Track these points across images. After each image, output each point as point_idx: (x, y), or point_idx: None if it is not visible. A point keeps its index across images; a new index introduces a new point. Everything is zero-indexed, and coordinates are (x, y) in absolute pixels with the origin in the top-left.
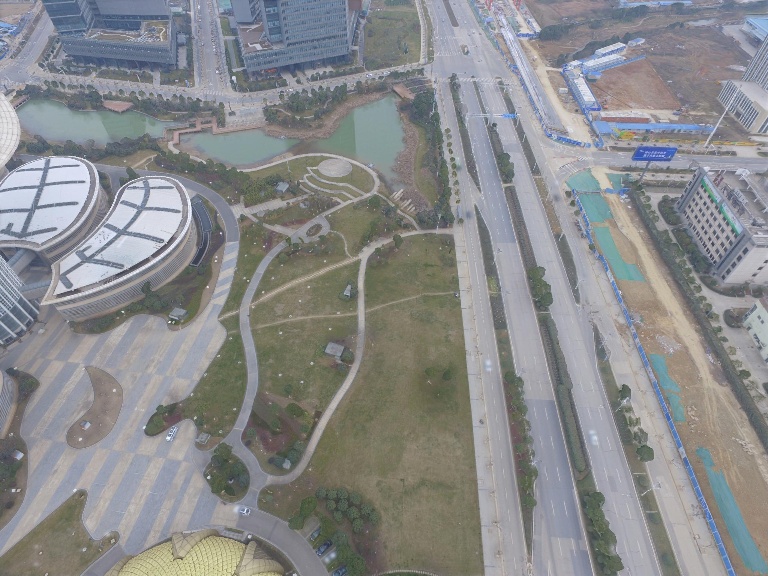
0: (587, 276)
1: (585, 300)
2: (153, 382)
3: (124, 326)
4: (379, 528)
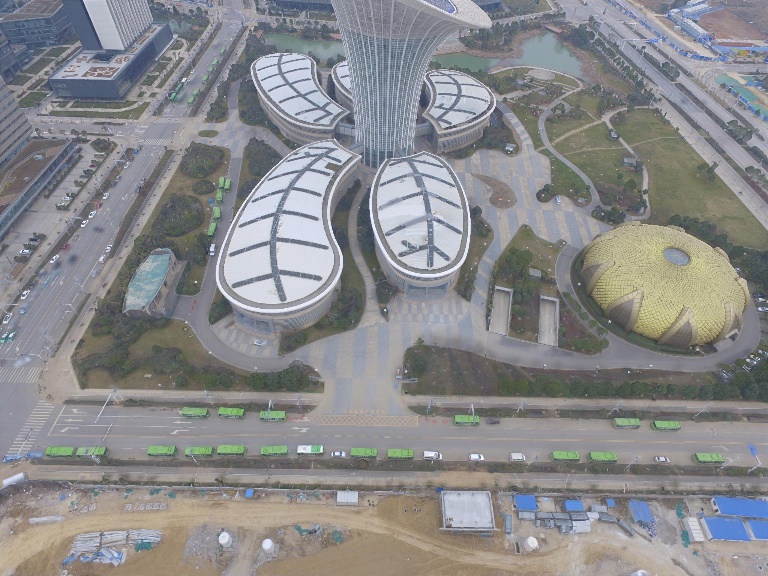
0: (761, 128)
1: (767, 140)
2: (522, 180)
3: (476, 155)
4: (716, 232)
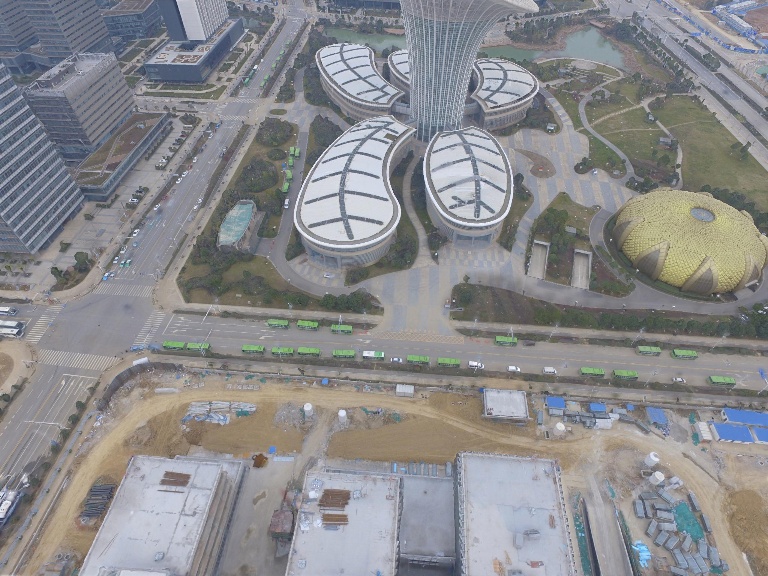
0: None
1: None
2: (561, 155)
3: (519, 133)
4: None
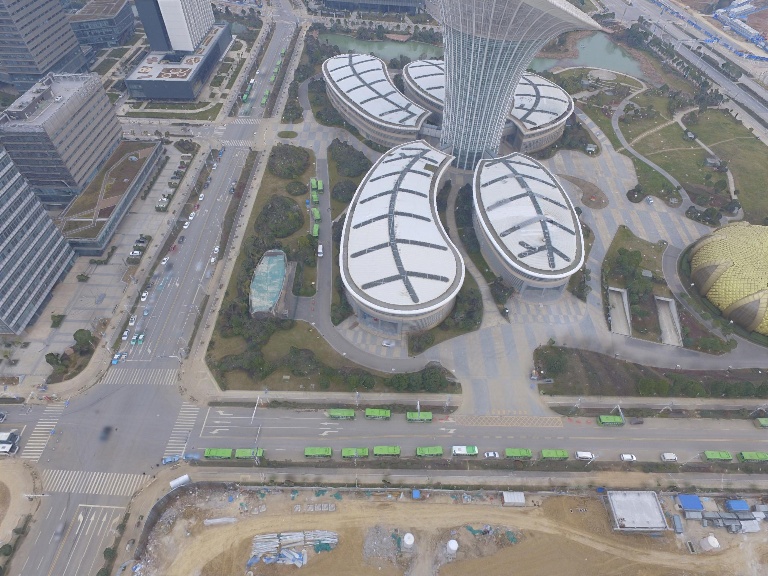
0: None
1: None
2: (609, 180)
3: (558, 156)
4: None
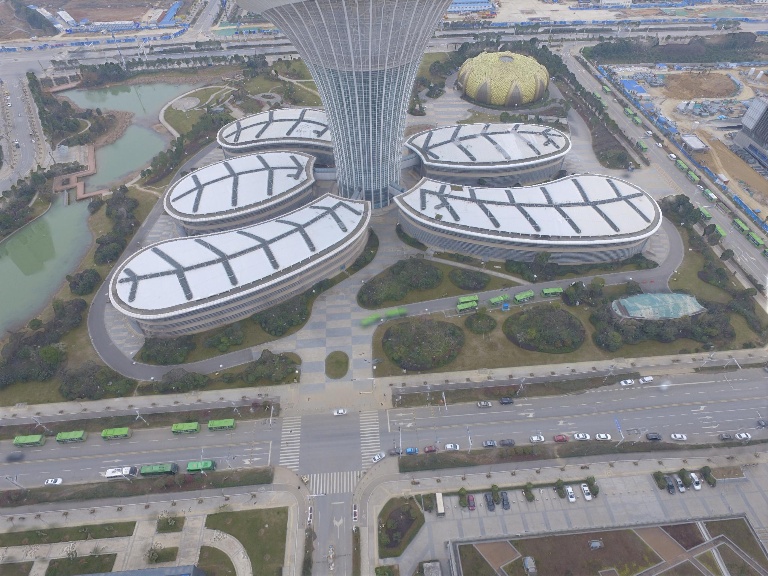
0: None
1: None
2: None
3: None
4: None
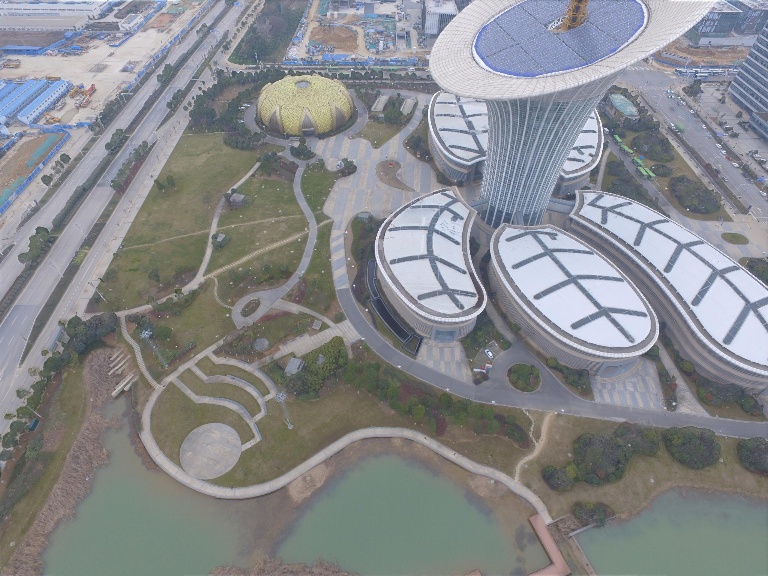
0: None
1: (4, 248)
2: (364, 185)
3: None
4: None
